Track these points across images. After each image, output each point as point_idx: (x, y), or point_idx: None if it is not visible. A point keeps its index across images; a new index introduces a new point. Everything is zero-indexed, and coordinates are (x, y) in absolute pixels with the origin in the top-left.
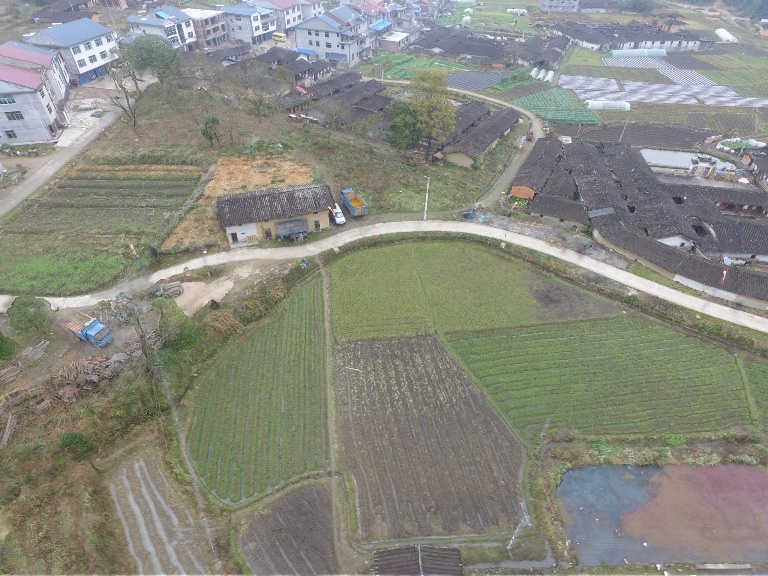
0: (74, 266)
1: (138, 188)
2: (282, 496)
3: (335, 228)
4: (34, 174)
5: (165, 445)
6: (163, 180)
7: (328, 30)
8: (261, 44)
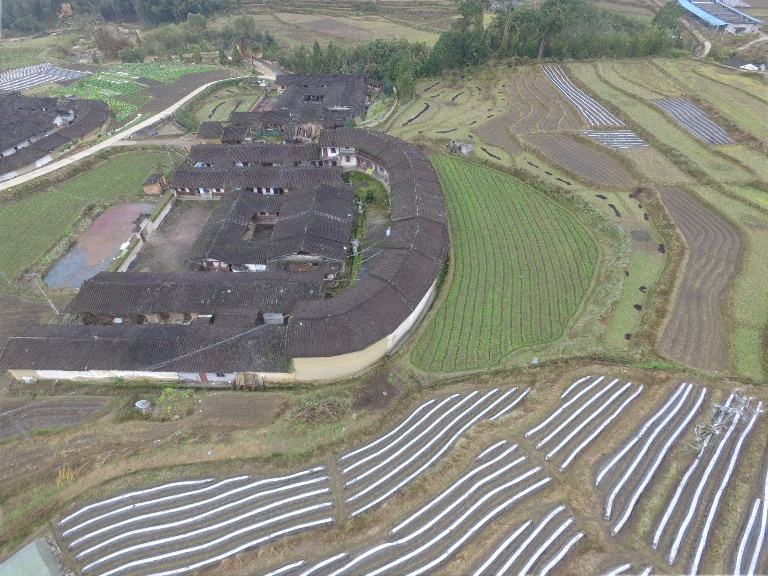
0: None
1: None
2: None
3: None
4: None
5: None
6: None
7: None
8: None
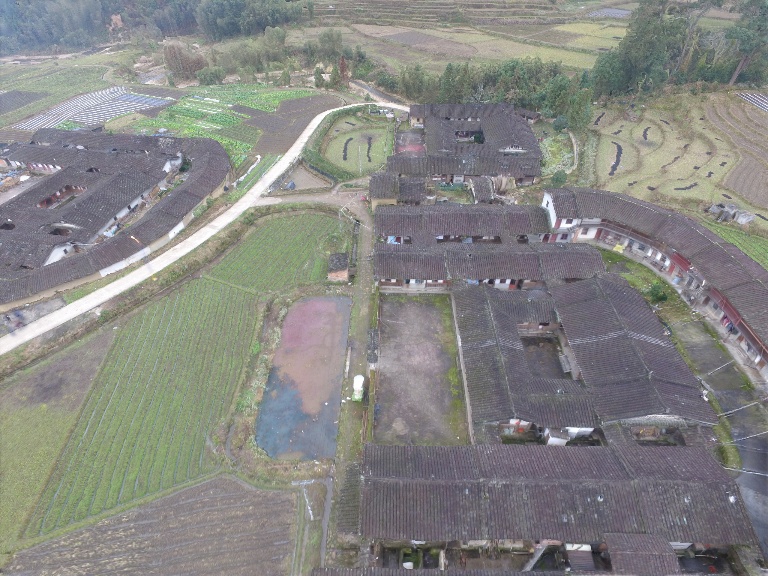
0: None
1: None
2: None
3: None
4: None
5: None
6: None
7: None
8: None
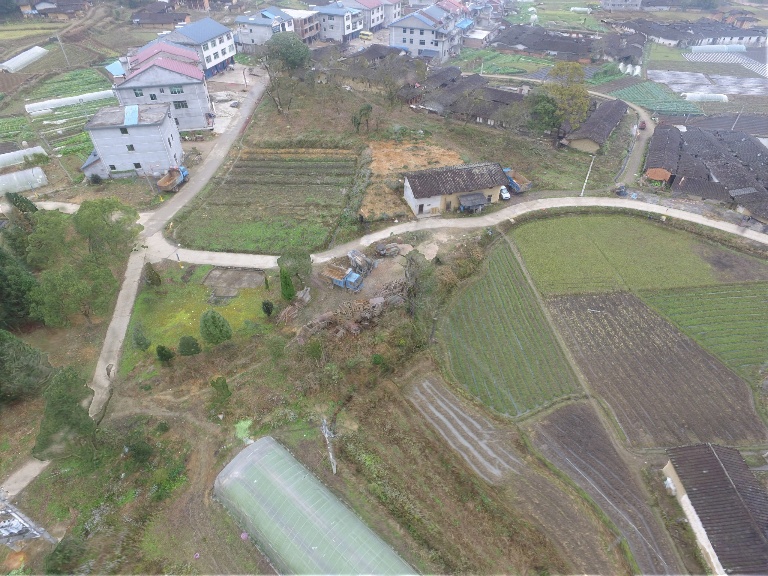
0: (285, 232)
1: (306, 168)
2: (554, 412)
3: (503, 203)
4: (208, 156)
5: (439, 370)
6: (325, 162)
7: (423, 28)
8: (350, 42)
